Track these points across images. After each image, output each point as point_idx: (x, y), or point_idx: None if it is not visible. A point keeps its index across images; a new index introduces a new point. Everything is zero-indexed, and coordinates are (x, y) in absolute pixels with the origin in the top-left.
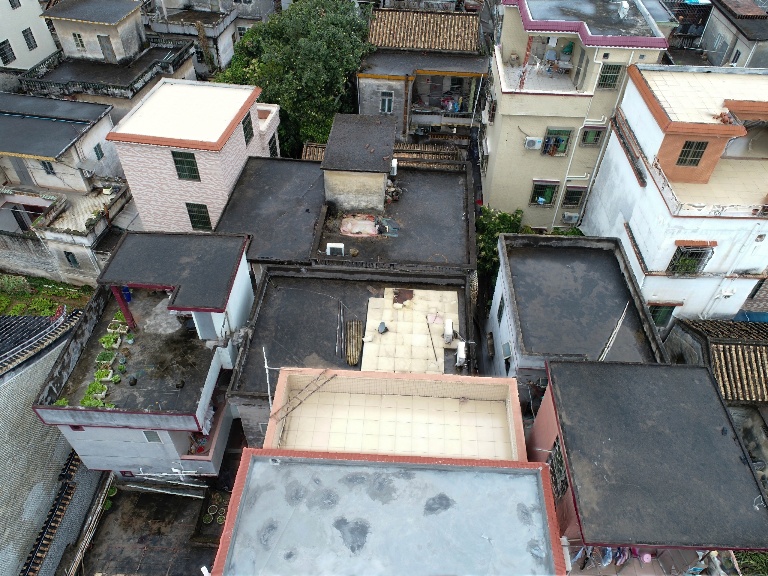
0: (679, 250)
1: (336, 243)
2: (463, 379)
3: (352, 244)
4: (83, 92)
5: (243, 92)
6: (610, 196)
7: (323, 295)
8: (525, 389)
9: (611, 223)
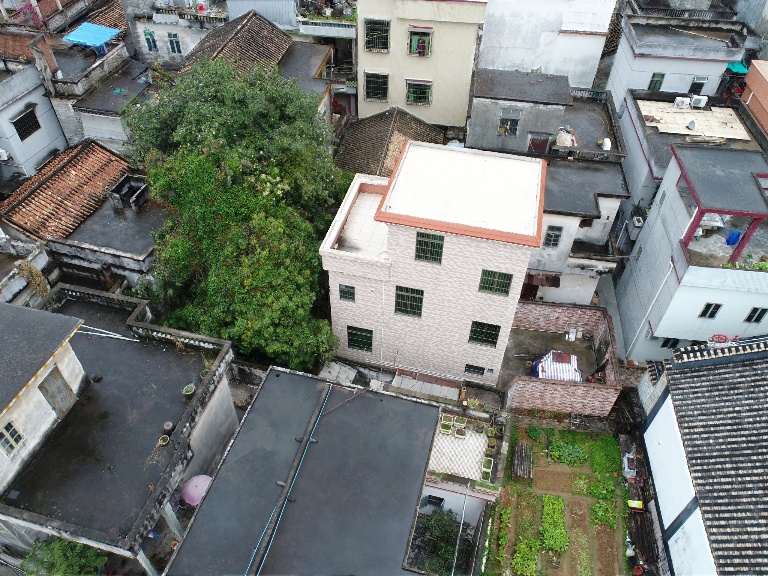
0: (615, 8)
1: (606, 141)
2: (765, 72)
3: (586, 145)
4: (190, 431)
5: (417, 151)
6: (519, 35)
7: (665, 151)
8: (729, 76)
9: (533, 47)
